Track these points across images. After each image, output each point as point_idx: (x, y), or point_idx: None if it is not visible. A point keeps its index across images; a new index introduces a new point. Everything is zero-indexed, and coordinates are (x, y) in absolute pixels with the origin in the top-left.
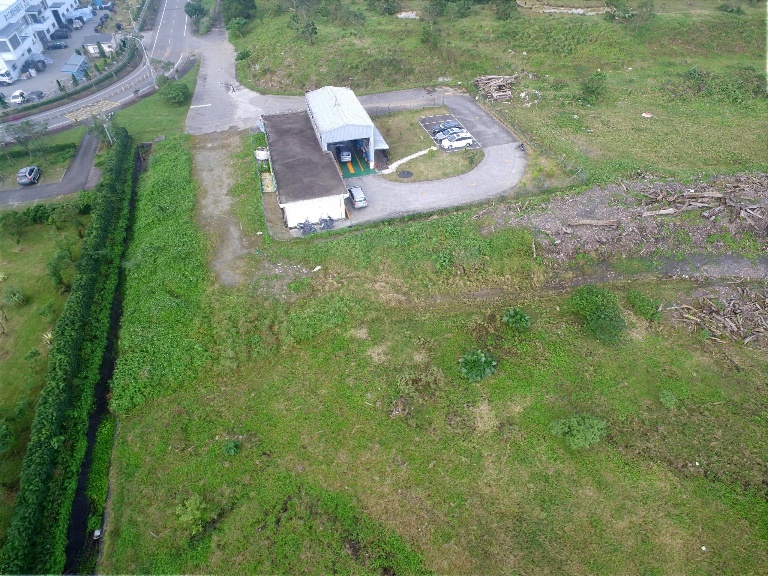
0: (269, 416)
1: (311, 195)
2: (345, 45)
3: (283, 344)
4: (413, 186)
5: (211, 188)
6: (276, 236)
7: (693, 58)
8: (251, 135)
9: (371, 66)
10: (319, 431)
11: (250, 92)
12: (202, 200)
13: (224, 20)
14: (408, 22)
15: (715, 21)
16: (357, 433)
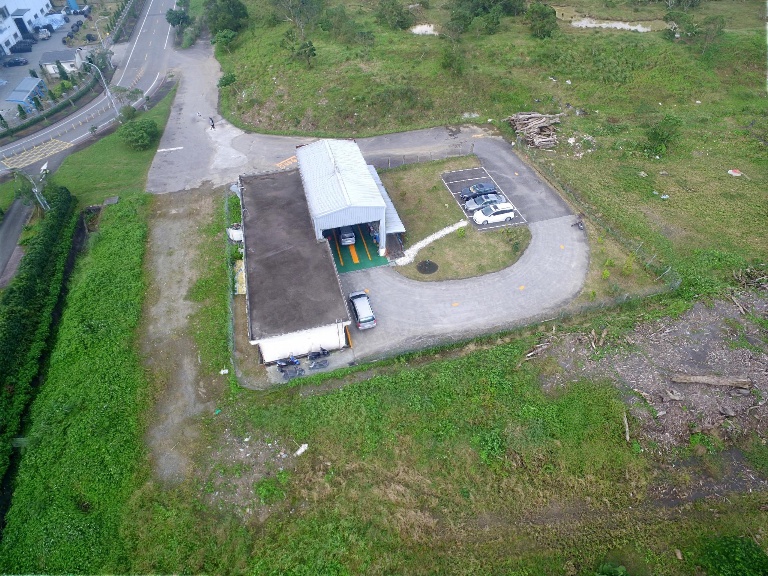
0: None
1: (297, 321)
2: (349, 70)
3: None
4: (438, 288)
5: (166, 286)
6: (246, 379)
7: None
8: (227, 198)
9: (381, 99)
10: None
11: (233, 129)
12: (151, 307)
13: (210, 31)
14: (425, 40)
15: None
16: None
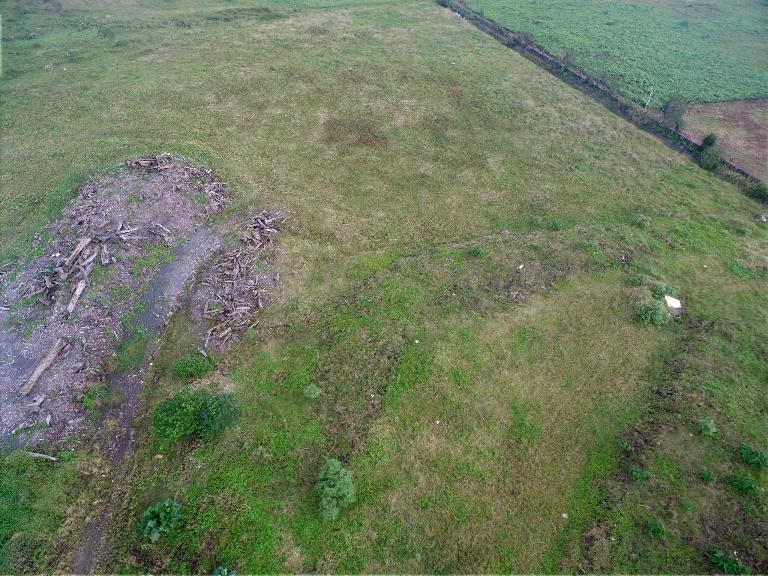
0: None
1: None
2: None
3: None
4: None
5: None
6: None
7: None
8: None
9: None
10: None
11: None
12: None
13: None
14: None
15: None
16: None
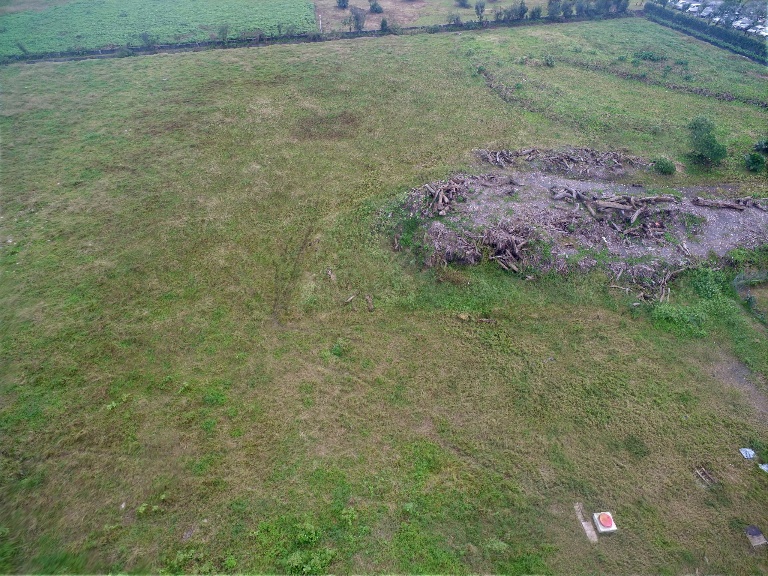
0: None
1: None
2: None
3: None
4: None
5: None
6: None
7: None
8: None
9: None
10: None
11: None
12: None
13: None
14: None
15: None
16: None
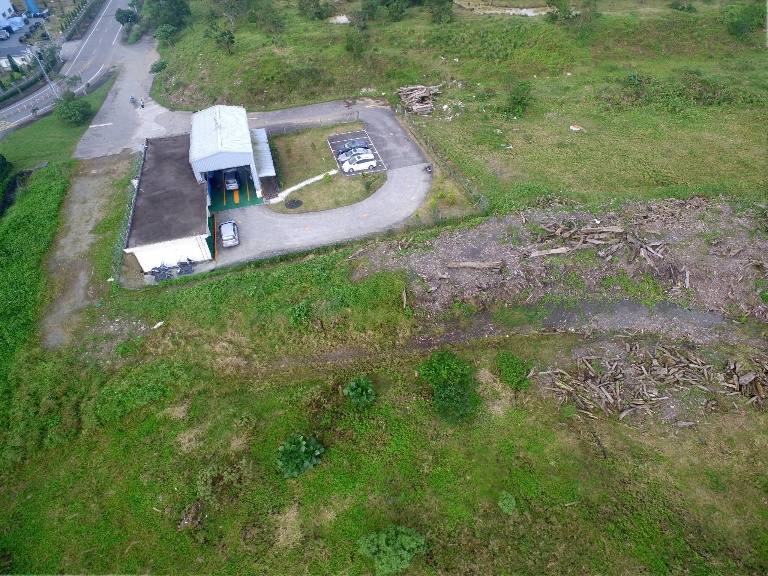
0: (35, 528)
1: (165, 236)
2: (264, 55)
3: (84, 427)
4: (298, 218)
5: (76, 224)
6: (127, 283)
7: (638, 61)
8: (140, 159)
9: (288, 78)
10: (85, 551)
11: (159, 108)
12: (61, 239)
13: (154, 27)
14: (336, 28)
15: (664, 20)
16: (130, 552)
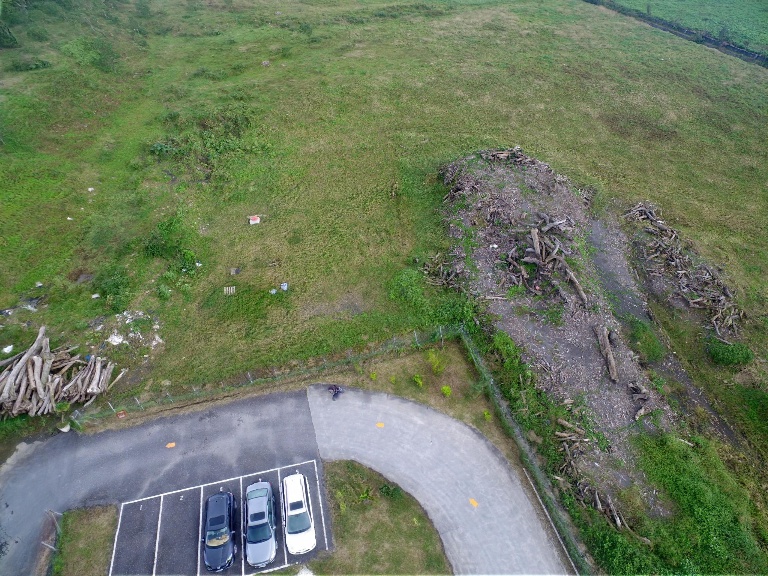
0: None
1: None
2: None
3: None
4: None
5: None
6: None
7: (103, 135)
8: None
9: None
10: None
11: None
12: None
13: None
14: None
15: (49, 85)
16: None
